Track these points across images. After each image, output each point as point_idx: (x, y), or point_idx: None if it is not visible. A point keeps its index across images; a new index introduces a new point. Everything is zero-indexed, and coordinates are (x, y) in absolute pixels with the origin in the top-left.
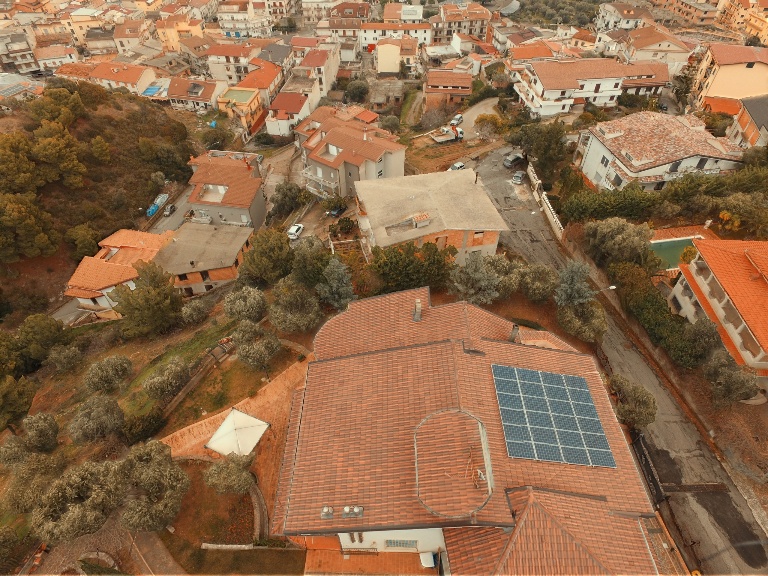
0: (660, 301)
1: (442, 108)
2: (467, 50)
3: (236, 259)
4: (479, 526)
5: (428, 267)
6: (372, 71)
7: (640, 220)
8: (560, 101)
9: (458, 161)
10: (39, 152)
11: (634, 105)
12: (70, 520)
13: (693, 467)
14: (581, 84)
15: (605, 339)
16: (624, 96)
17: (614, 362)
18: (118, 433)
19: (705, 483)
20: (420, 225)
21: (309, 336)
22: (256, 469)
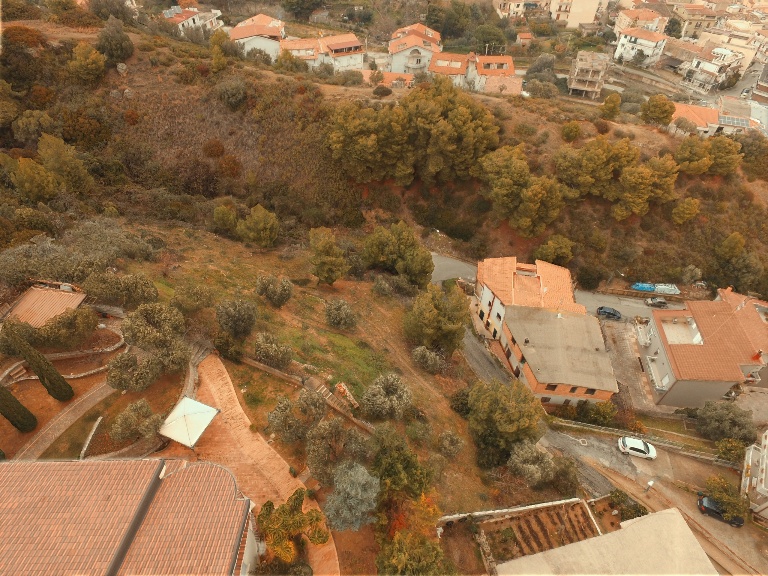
0: None
1: None
2: None
3: (555, 384)
4: None
5: None
6: None
7: None
8: None
9: None
10: (625, 172)
11: None
12: (125, 322)
13: None
14: None
15: None
16: None
17: None
18: (221, 331)
19: None
20: None
21: None
22: (170, 449)
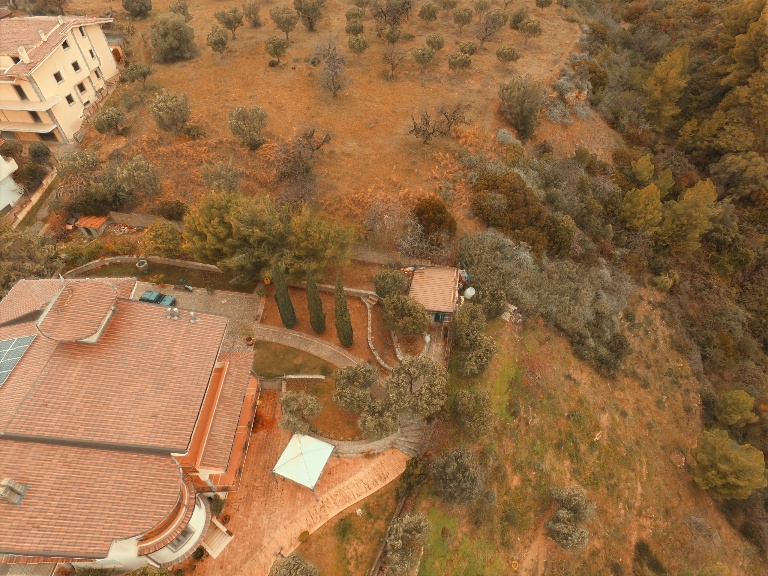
0: None
1: None
2: None
3: None
4: None
5: None
6: None
7: None
8: None
9: None
10: None
11: None
12: None
13: None
14: None
15: None
16: None
17: None
18: None
19: None
20: None
21: None
22: None
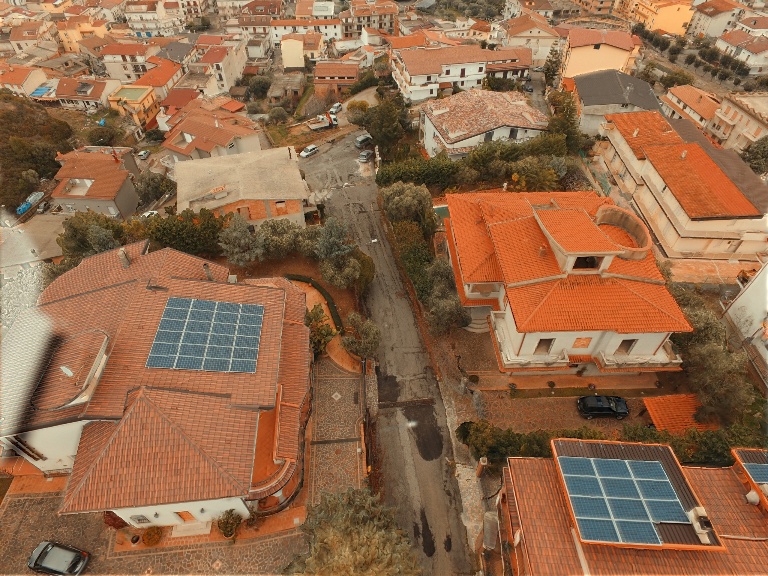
0: (422, 251)
1: (327, 98)
2: (375, 44)
3: None
4: (88, 420)
5: (202, 231)
6: (281, 67)
7: (450, 187)
8: (426, 86)
9: (314, 144)
10: None
11: (501, 88)
12: None
13: (412, 387)
14: (446, 69)
15: (383, 290)
16: (491, 80)
17: (382, 308)
18: None
19: (417, 399)
20: (218, 197)
21: None
22: None
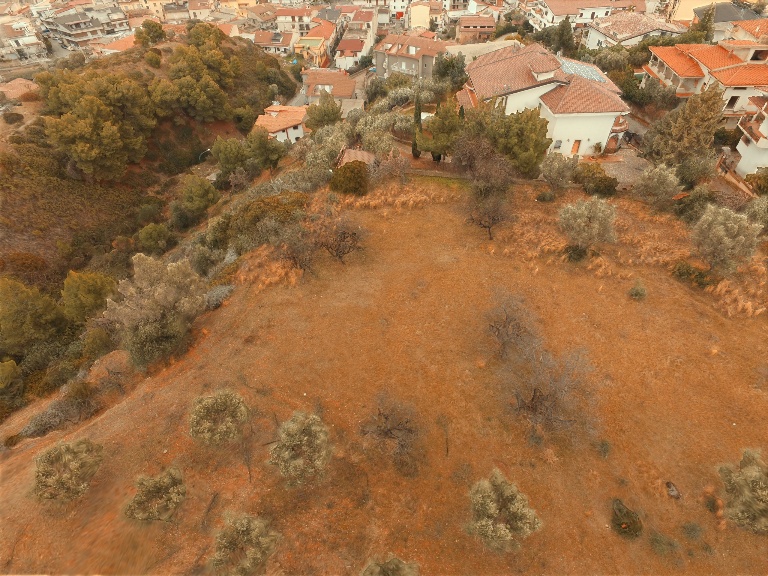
0: (632, 82)
1: None
2: None
3: None
4: (557, 83)
5: None
6: None
7: None
8: None
9: None
10: (209, 58)
11: None
12: (378, 122)
13: None
14: (581, 12)
15: None
16: None
17: None
18: None
19: None
20: None
21: (443, 102)
22: None
